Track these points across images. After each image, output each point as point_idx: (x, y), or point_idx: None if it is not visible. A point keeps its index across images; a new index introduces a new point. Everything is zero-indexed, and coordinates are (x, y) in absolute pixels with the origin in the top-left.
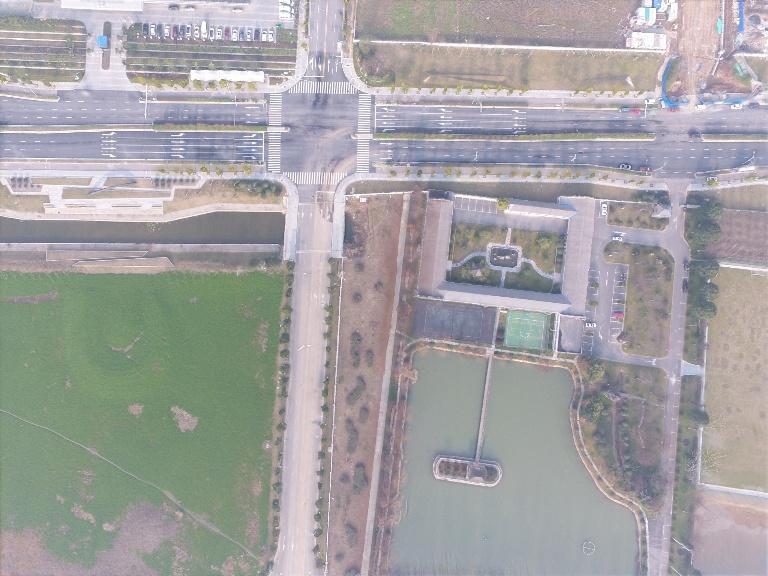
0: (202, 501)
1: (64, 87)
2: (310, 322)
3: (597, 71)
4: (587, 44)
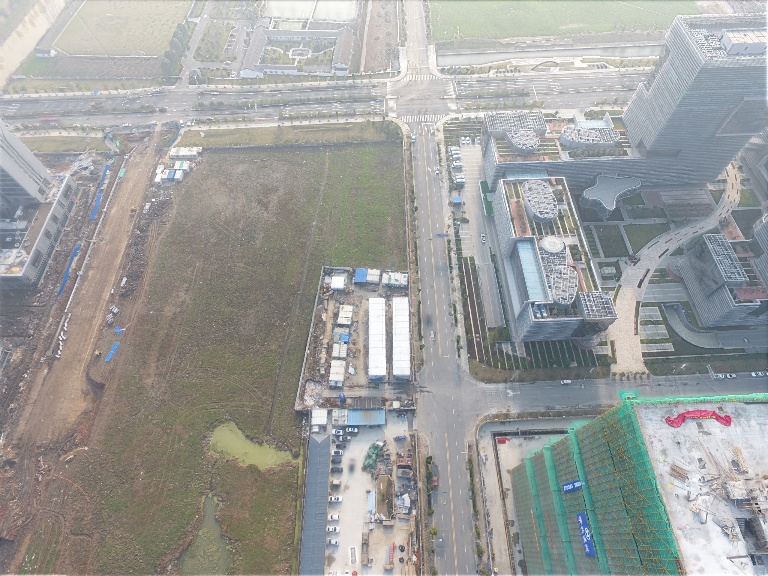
0: None
1: (595, 108)
2: (415, 25)
3: (226, 138)
4: (230, 152)
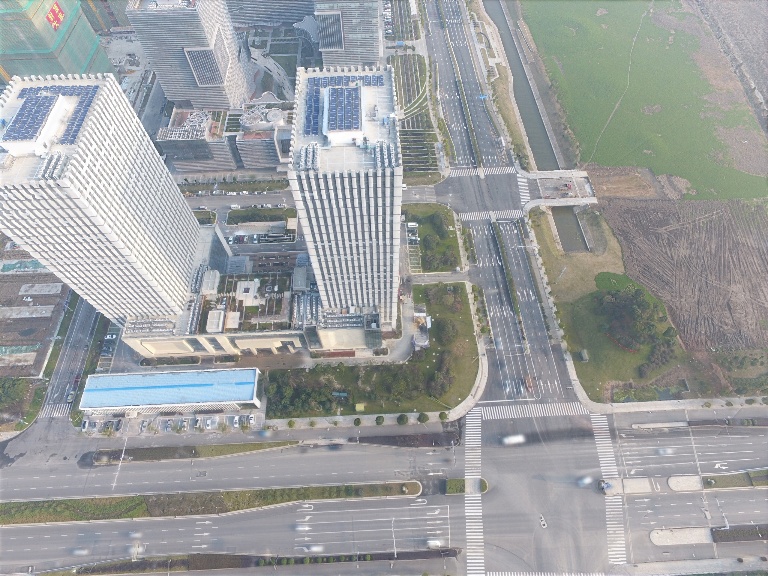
0: (641, 5)
1: None
2: None
3: None
4: None
